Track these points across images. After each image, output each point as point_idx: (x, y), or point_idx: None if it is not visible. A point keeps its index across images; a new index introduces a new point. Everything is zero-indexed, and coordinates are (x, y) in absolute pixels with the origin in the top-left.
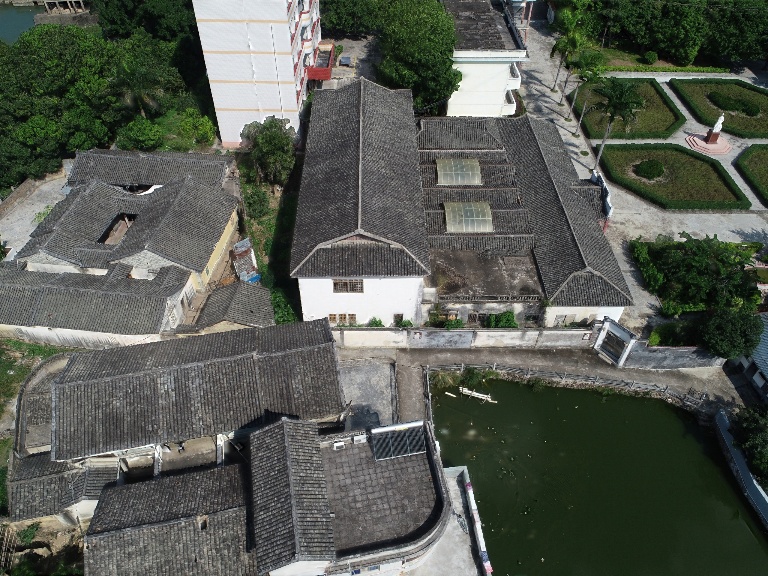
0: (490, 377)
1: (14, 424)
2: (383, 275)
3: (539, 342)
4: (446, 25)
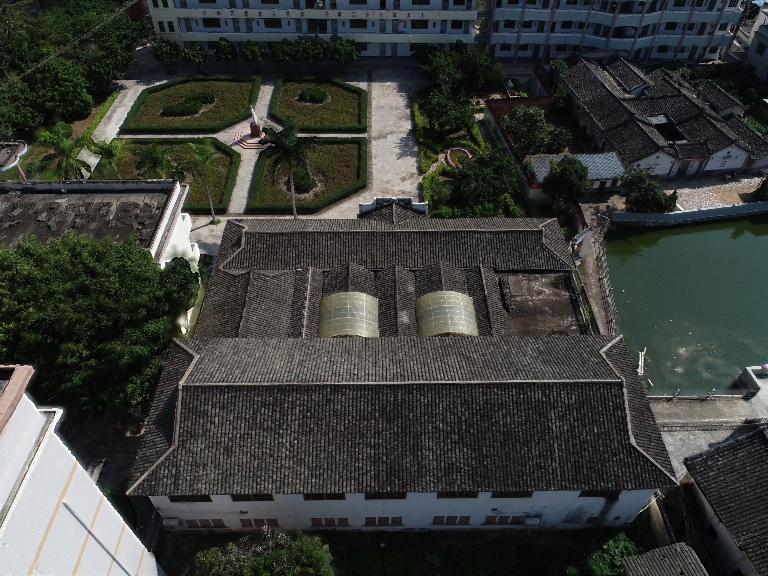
0: None
1: None
2: None
3: None
4: (76, 244)
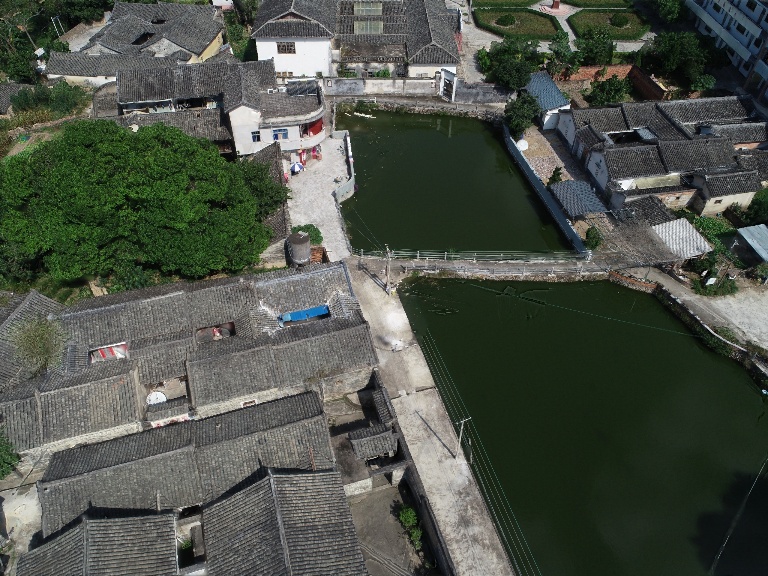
0: (374, 109)
1: (89, 116)
2: (305, 36)
3: (405, 90)
4: None
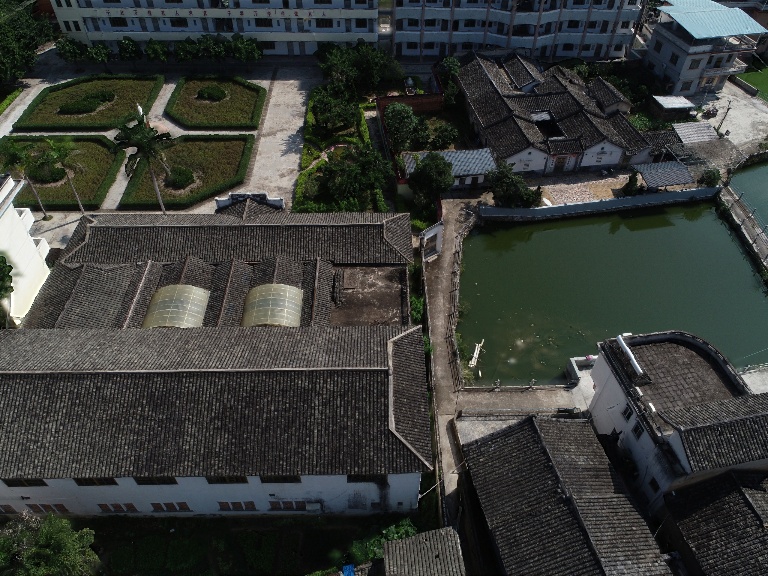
0: None
1: None
2: None
3: None
4: None
